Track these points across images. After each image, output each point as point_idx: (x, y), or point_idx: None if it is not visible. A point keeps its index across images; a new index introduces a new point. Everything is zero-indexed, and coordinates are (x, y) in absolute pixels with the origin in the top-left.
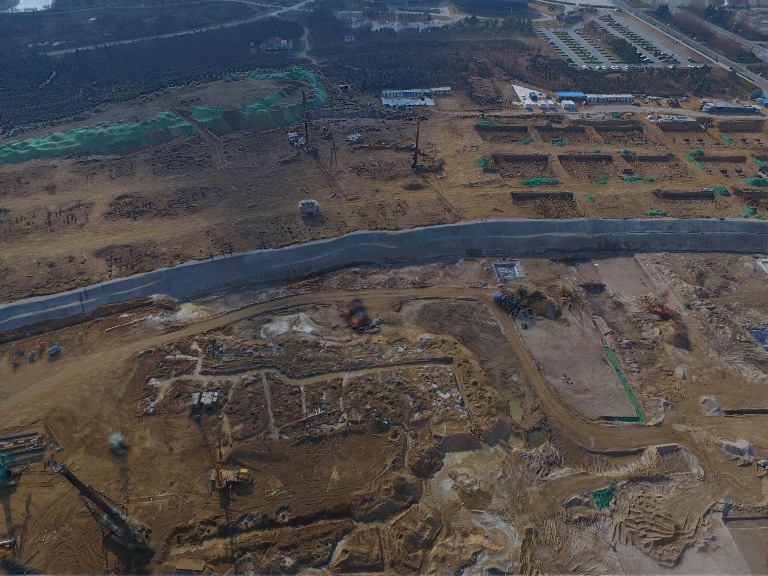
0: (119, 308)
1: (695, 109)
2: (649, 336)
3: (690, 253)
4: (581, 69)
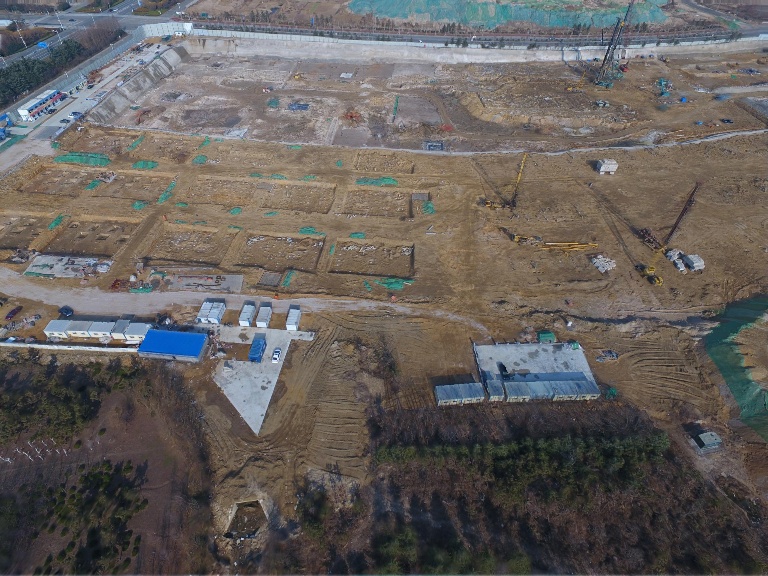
0: None
1: None
2: (367, 114)
3: None
4: None
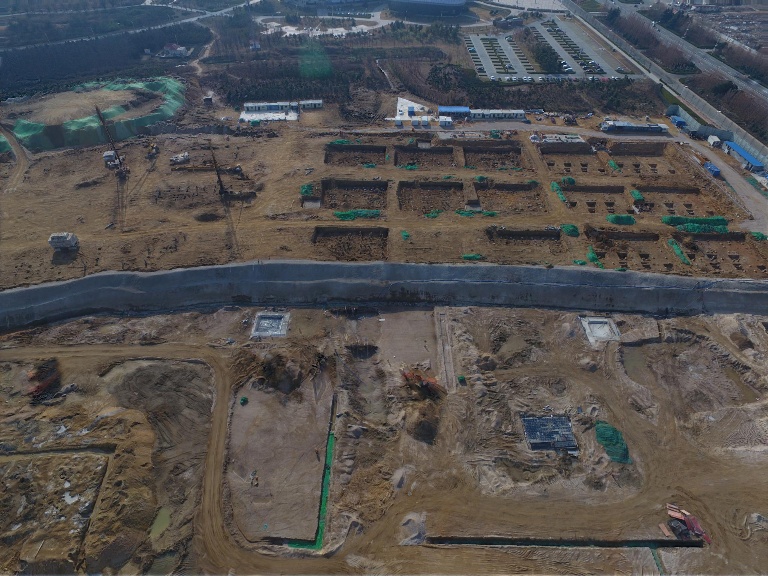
0: None
1: (593, 128)
2: (392, 421)
3: (503, 308)
4: (487, 80)
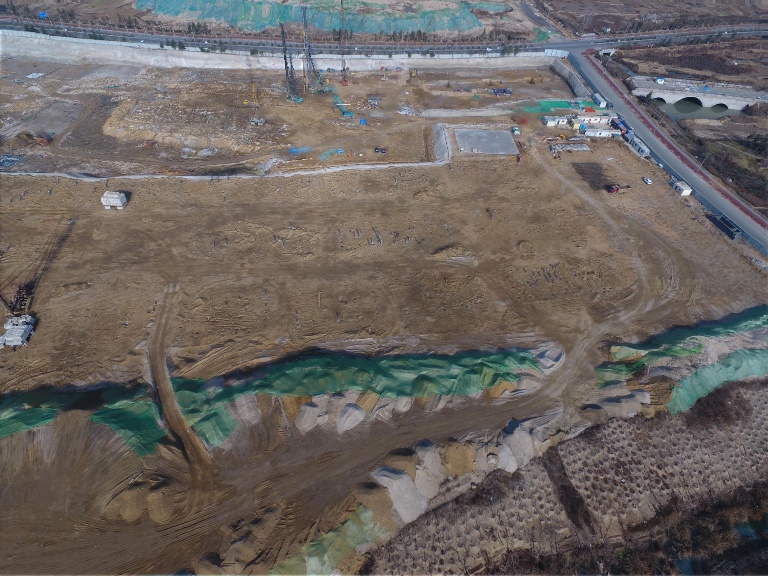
0: None
1: None
2: None
3: None
4: None
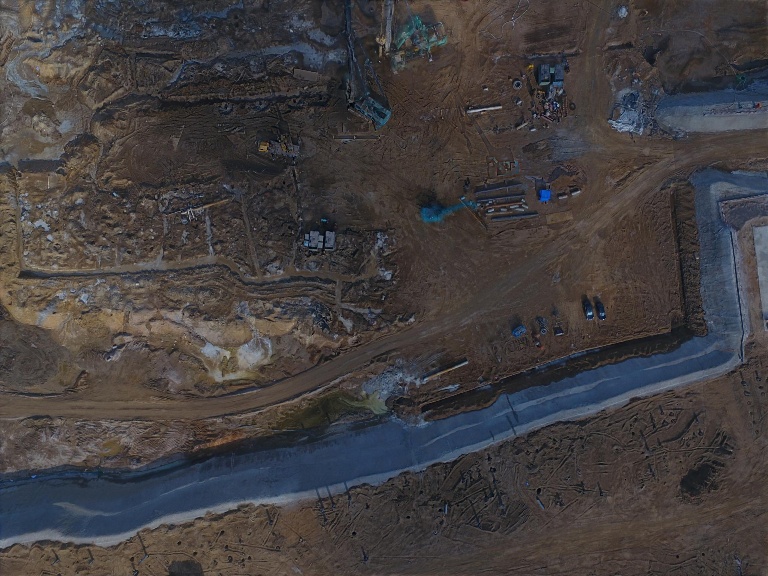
0: (463, 402)
1: None
2: None
3: None
4: None
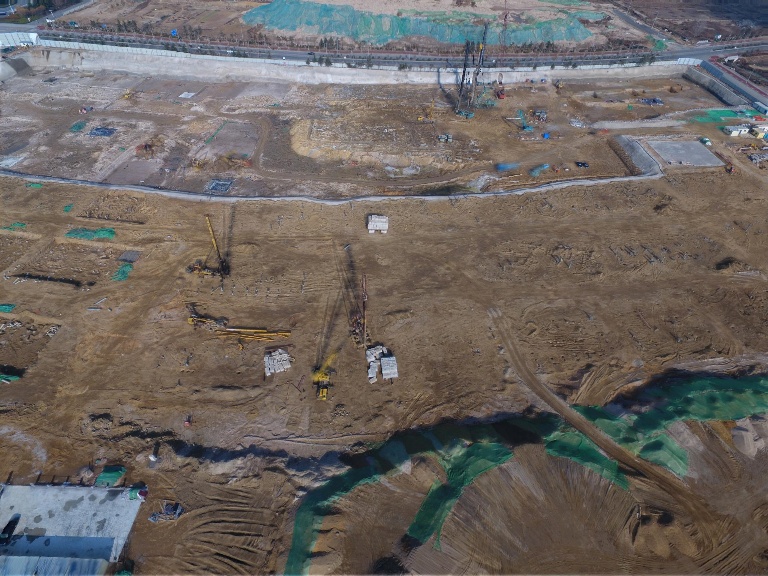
0: None
1: None
2: (173, 143)
3: (52, 176)
4: None
